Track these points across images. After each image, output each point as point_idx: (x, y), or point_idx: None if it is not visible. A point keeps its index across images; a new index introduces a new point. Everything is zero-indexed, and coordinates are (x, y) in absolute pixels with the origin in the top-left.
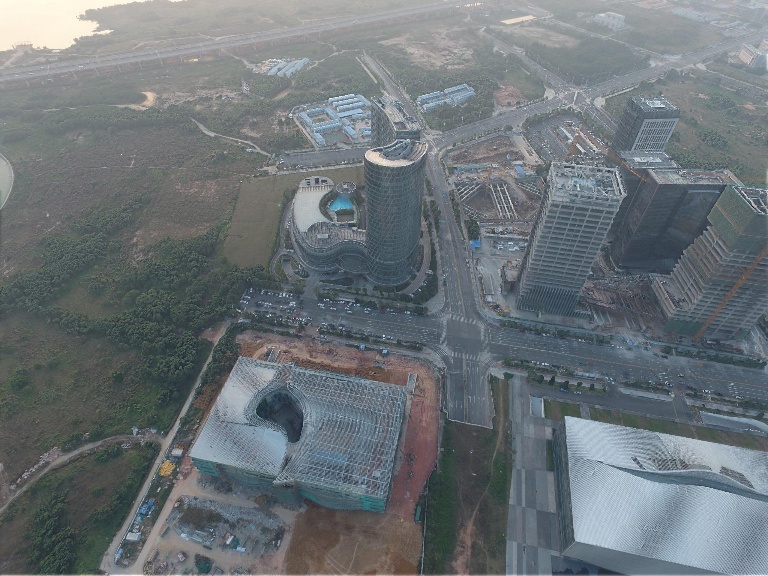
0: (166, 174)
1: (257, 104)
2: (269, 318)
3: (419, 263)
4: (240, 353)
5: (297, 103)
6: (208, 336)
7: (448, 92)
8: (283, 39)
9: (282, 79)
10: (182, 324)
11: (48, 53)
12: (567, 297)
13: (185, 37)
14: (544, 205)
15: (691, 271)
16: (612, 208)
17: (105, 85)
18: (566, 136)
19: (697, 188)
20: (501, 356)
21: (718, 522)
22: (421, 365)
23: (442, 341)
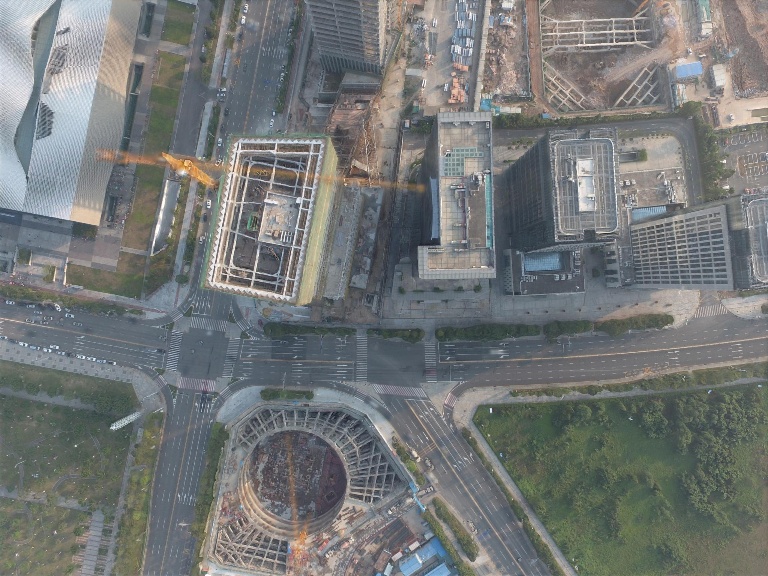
0: None
1: None
2: None
3: None
4: None
5: None
6: None
7: None
8: None
9: None
10: None
11: None
12: None
13: None
14: None
15: None
16: None
17: None
18: None
19: None
20: None
21: (1, 83)
22: None
23: None
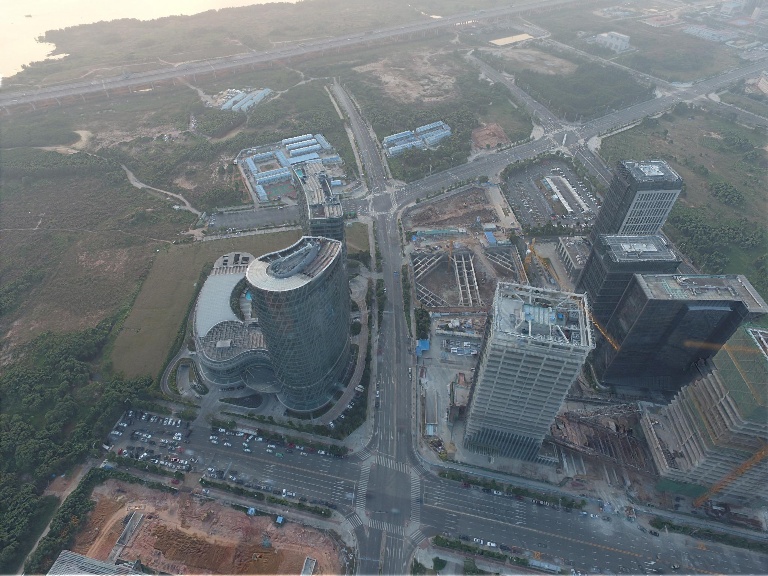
0: (72, 240)
1: (199, 147)
2: (138, 463)
3: (349, 374)
4: (91, 518)
5: (245, 145)
6: (57, 488)
7: (420, 131)
8: (248, 65)
9: (235, 115)
10: (27, 469)
11: None
12: (526, 443)
13: (142, 63)
14: (487, 339)
15: (691, 421)
16: (576, 359)
17: (35, 123)
18: (551, 189)
19: (700, 304)
20: (434, 528)
21: None
22: (325, 542)
23: (359, 501)
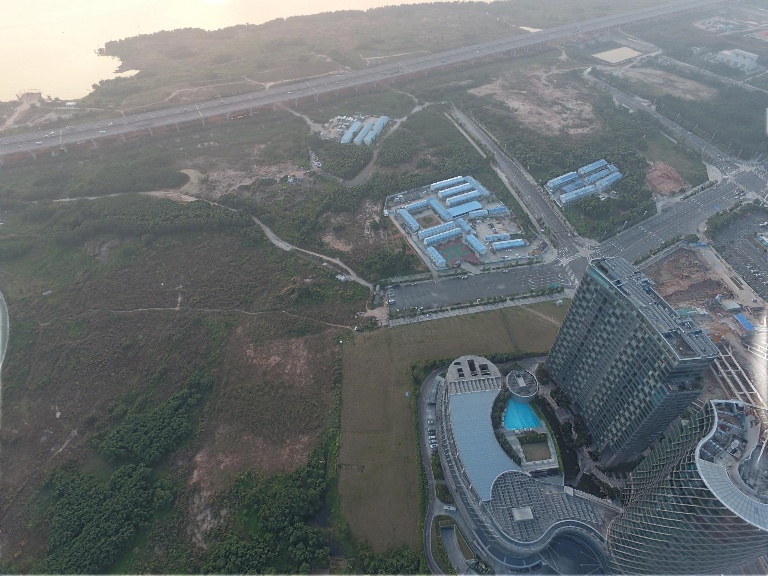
0: (230, 326)
1: (338, 194)
2: None
3: None
4: None
5: (390, 191)
6: None
7: (584, 173)
8: None
9: (363, 151)
10: None
11: (61, 106)
12: None
13: (228, 82)
14: None
15: None
16: None
17: (134, 161)
18: None
19: None
20: None
21: None
22: None
23: None
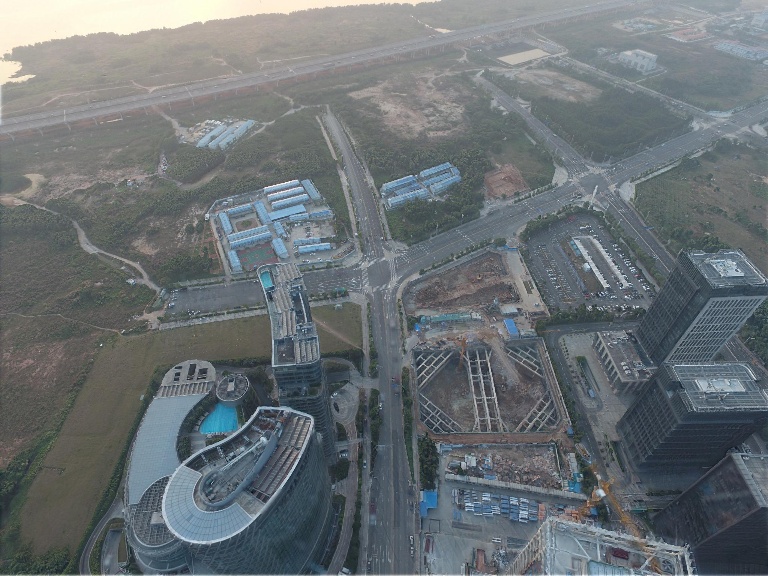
0: None
1: (166, 198)
2: None
3: (330, 547)
4: None
5: (220, 195)
6: None
7: (424, 176)
8: None
9: (211, 155)
10: None
11: None
12: None
13: (114, 87)
14: None
15: None
16: None
17: None
18: (581, 255)
19: None
20: None
21: None
22: None
23: None
